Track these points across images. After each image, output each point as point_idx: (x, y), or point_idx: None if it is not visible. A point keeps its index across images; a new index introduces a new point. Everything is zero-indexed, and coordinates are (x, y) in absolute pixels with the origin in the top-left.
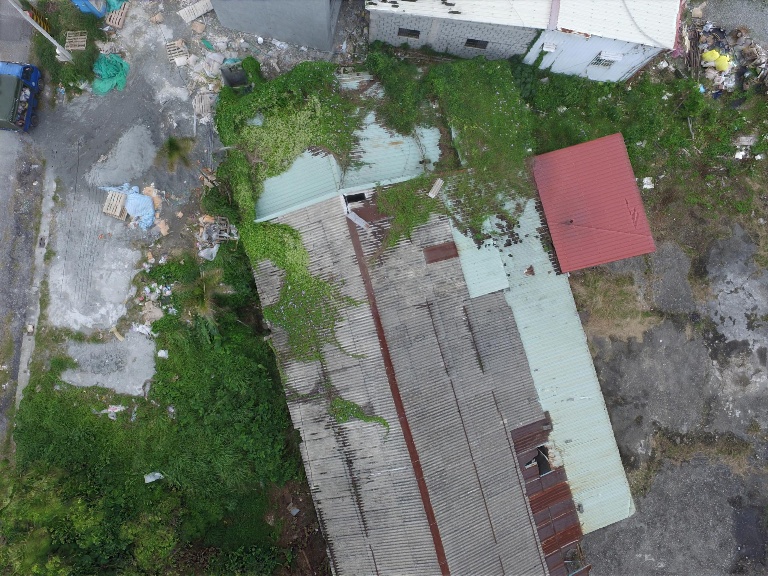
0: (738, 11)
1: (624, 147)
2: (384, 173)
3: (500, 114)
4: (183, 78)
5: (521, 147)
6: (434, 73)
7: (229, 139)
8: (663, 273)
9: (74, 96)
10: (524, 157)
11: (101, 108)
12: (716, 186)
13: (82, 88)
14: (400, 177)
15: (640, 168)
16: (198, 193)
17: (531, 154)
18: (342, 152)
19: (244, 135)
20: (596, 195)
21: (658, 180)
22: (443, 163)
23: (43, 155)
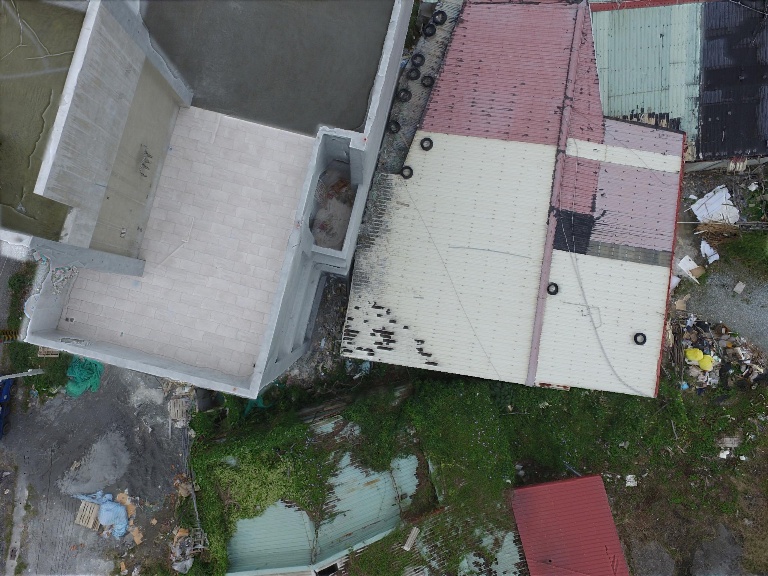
0: (723, 303)
1: (604, 492)
2: (359, 519)
3: (478, 445)
4: (158, 379)
5: (499, 479)
6: (411, 409)
7: (201, 480)
8: (646, 575)
9: (47, 398)
10: (503, 489)
11: (75, 411)
12: (700, 486)
13: (55, 392)
14: (374, 536)
15: (623, 467)
16: (173, 499)
17: (510, 487)
18: (315, 507)
19: (217, 474)
20: (575, 537)
21: (641, 478)
22: (420, 495)
23: (15, 462)
